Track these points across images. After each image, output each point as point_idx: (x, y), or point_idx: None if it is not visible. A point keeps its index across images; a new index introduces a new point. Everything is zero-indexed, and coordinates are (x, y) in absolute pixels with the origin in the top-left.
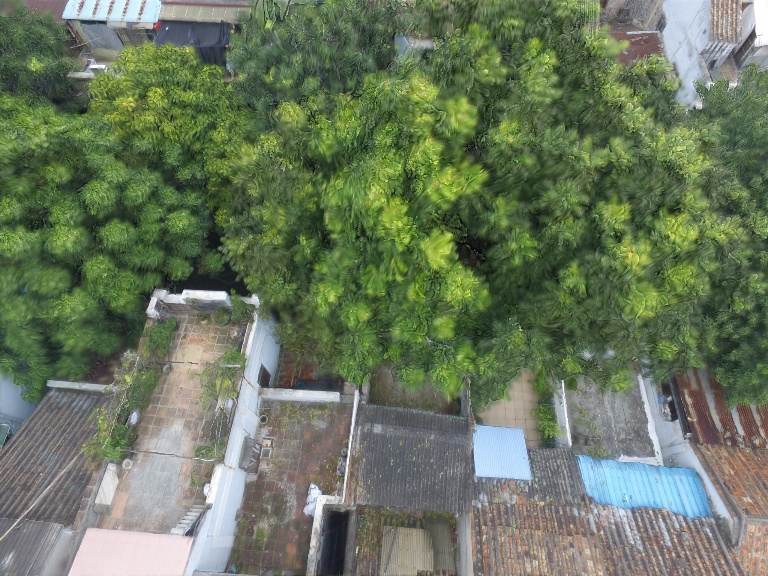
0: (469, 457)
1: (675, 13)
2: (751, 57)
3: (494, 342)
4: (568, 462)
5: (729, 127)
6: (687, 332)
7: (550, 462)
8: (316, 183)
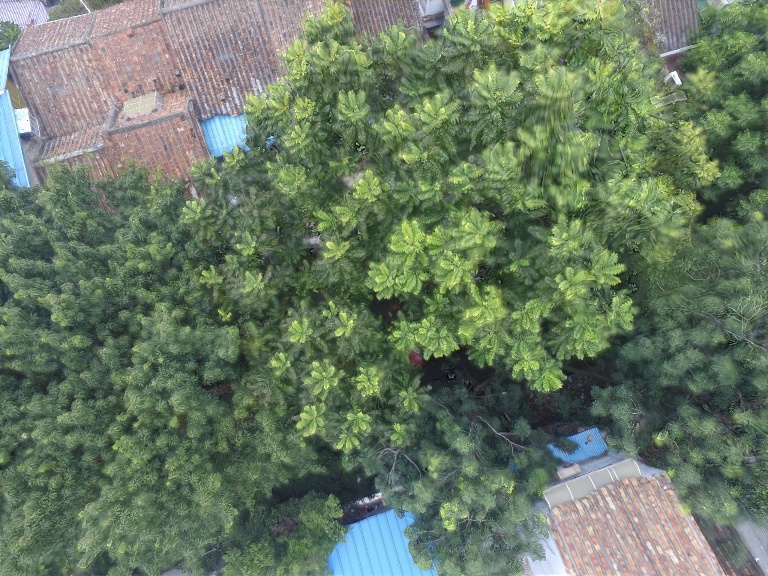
0: None
1: None
2: None
3: None
4: None
5: (200, 406)
6: None
7: None
8: (613, 135)
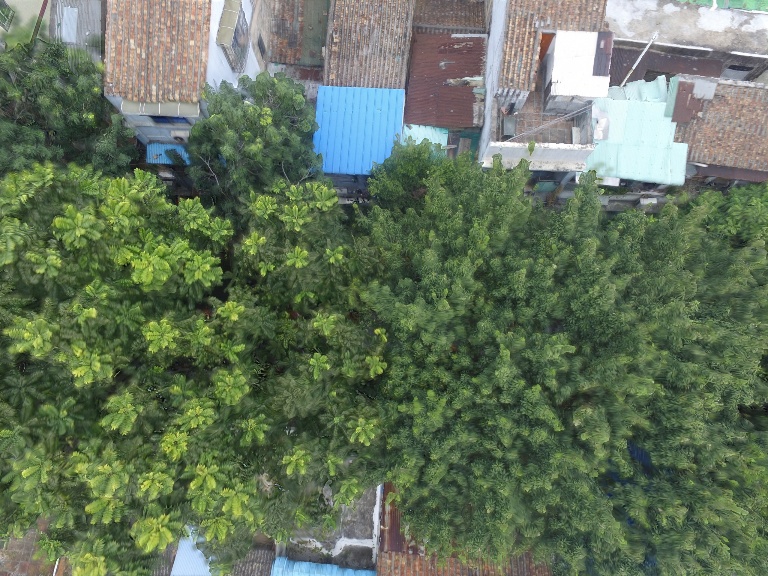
0: (171, 562)
1: (494, 22)
2: (553, 101)
3: (74, 557)
4: (262, 566)
5: None
6: (284, 532)
7: (246, 566)
8: None
